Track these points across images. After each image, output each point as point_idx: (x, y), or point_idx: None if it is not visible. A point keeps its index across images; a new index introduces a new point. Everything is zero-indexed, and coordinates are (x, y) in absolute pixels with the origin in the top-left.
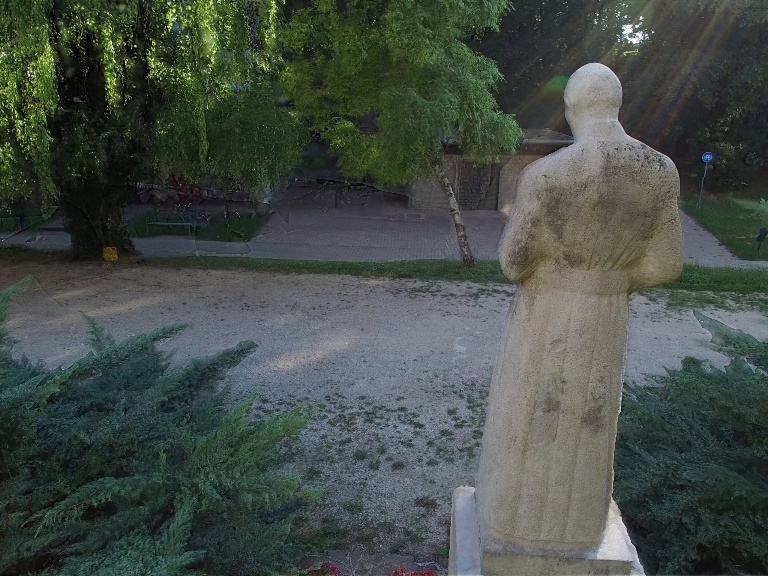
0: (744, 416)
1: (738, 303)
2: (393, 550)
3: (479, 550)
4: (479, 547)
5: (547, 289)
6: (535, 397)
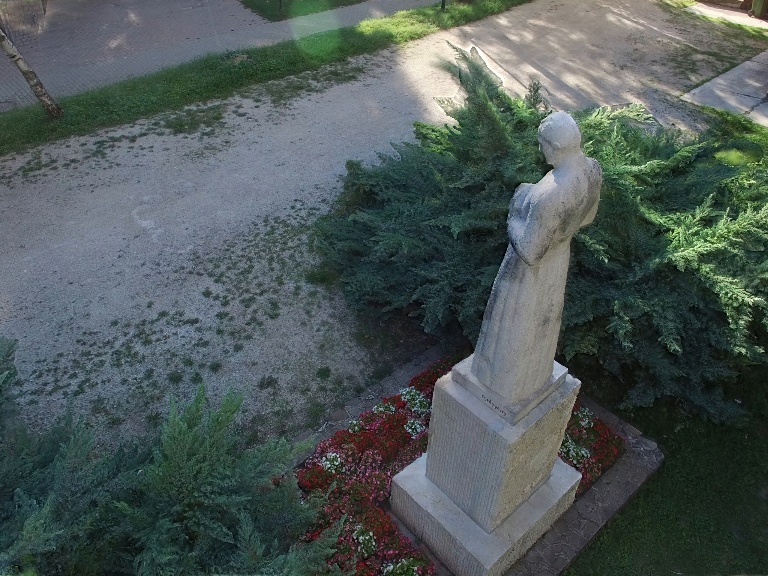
0: (484, 225)
1: (319, 82)
2: (281, 433)
3: (497, 413)
4: (495, 411)
5: (546, 260)
6: (539, 321)
